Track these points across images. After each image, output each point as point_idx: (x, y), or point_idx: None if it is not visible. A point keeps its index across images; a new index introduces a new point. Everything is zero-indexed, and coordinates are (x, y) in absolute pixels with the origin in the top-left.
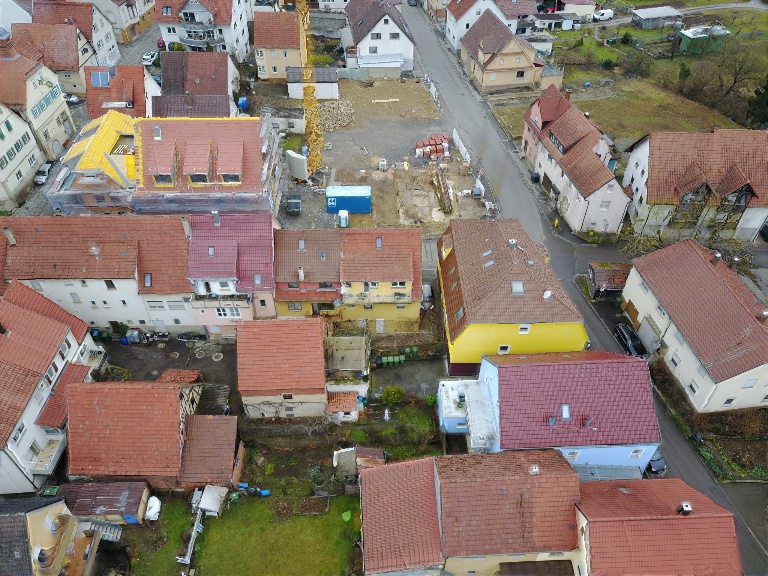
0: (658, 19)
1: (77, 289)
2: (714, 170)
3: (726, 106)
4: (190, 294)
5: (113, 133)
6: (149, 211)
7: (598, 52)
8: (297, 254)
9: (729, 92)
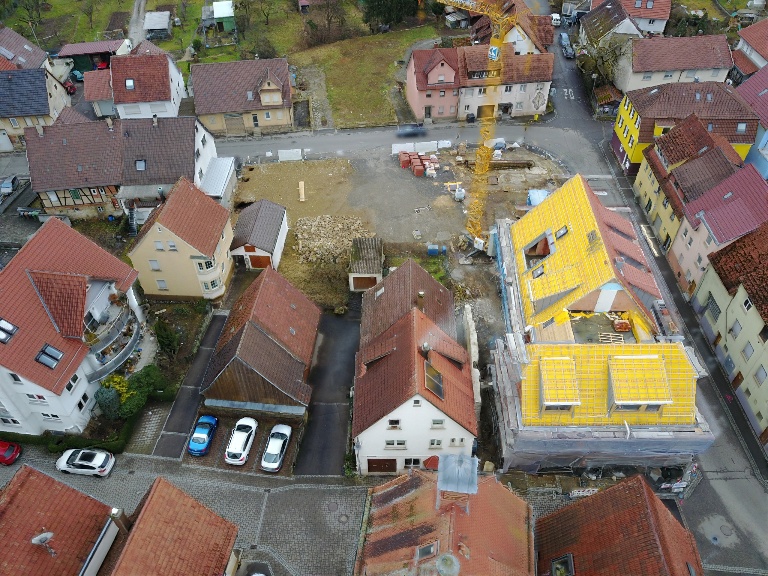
0: None
1: None
2: None
3: None
4: None
5: None
6: None
7: None
8: None
9: None
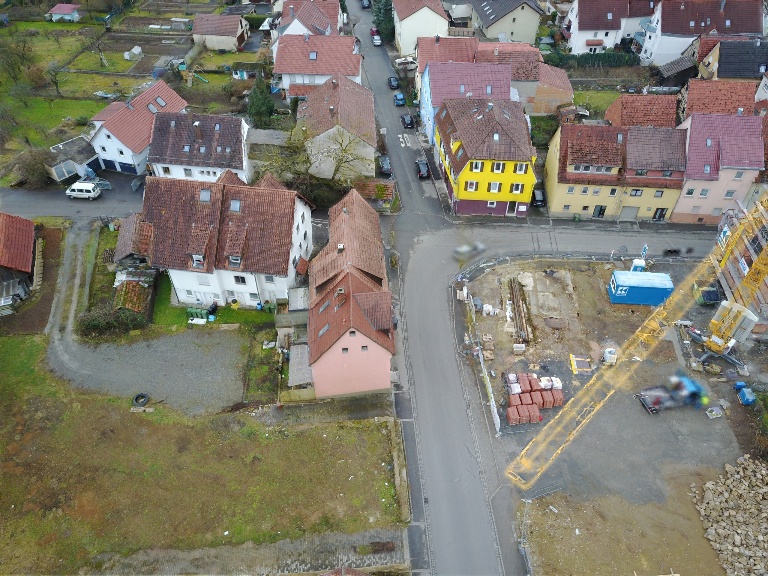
0: None
1: None
2: None
3: None
4: None
5: None
6: None
7: None
8: None
9: None
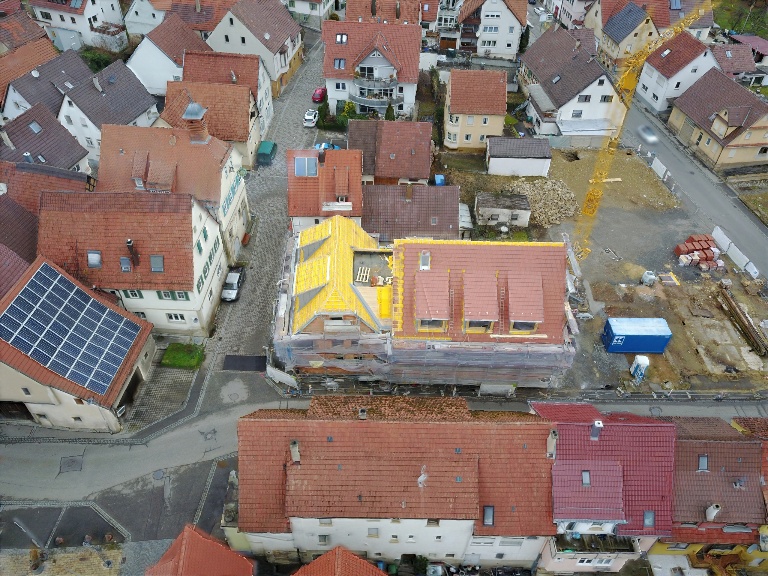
0: None
1: (382, 524)
2: None
3: None
4: (551, 539)
5: (348, 250)
6: (407, 363)
7: None
8: (697, 477)
9: None
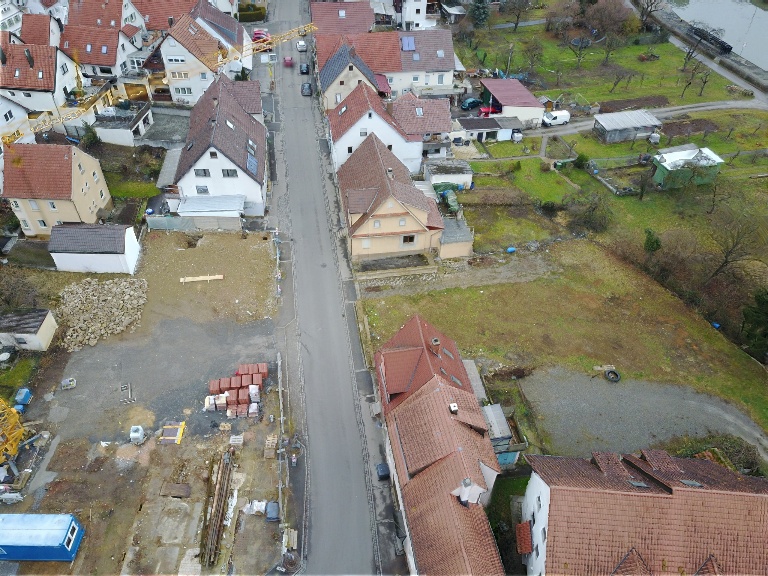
0: (628, 130)
1: None
2: (670, 567)
3: (713, 292)
4: None
5: None
6: None
7: (539, 183)
8: None
9: (717, 273)
